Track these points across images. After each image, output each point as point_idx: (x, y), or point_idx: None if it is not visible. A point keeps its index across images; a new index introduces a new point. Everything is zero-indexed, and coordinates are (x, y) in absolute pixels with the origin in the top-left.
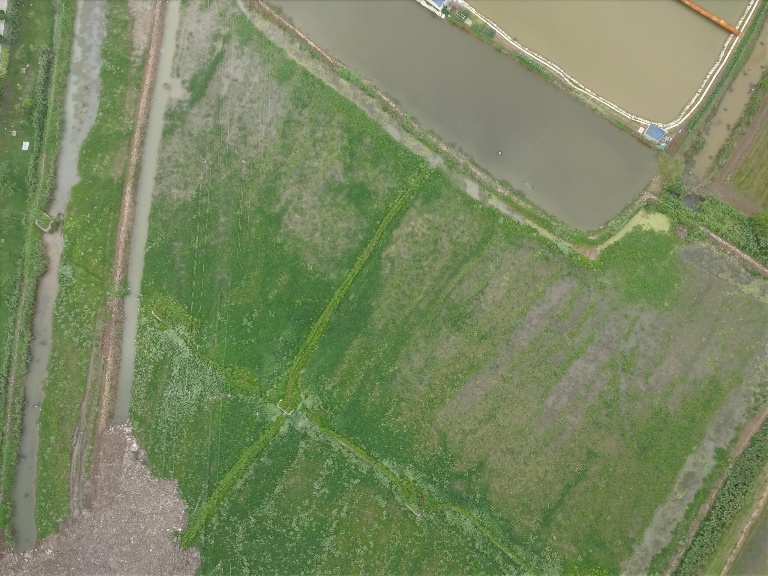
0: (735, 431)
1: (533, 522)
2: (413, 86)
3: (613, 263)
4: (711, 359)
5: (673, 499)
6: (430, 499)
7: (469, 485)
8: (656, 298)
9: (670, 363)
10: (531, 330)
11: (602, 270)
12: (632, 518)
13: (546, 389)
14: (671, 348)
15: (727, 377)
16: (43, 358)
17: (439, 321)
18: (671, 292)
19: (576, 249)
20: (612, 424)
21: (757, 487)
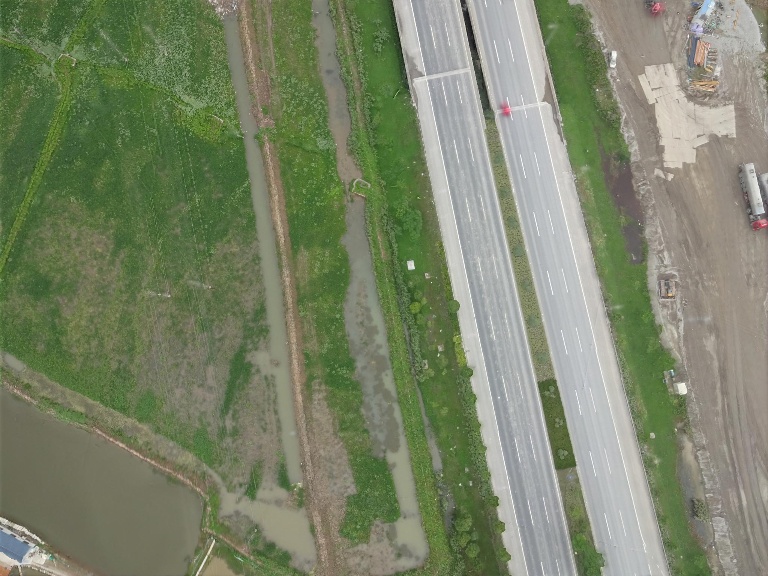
0: None
1: None
2: (2, 420)
3: None
4: None
5: None
6: None
7: None
8: None
9: None
10: None
11: None
12: None
13: None
14: None
15: None
16: (325, 58)
17: None
18: None
19: None
20: None
21: None
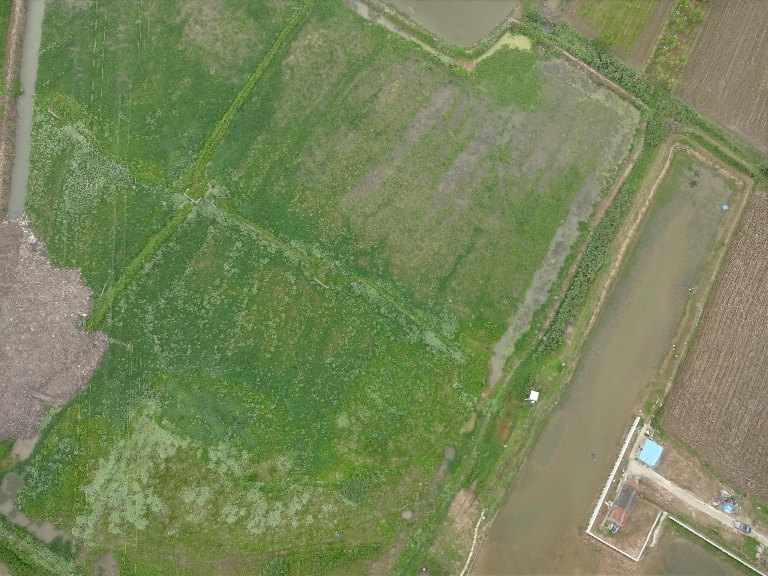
0: (593, 207)
1: (431, 288)
2: None
3: (487, 73)
4: (570, 151)
5: (548, 264)
6: (337, 271)
7: (372, 260)
8: (523, 102)
9: (538, 154)
10: (420, 128)
11: (478, 79)
12: (515, 281)
13: (436, 176)
14: (538, 142)
15: (584, 165)
16: None
17: (338, 120)
18: (535, 97)
19: (455, 62)
20: (494, 204)
21: (613, 250)
